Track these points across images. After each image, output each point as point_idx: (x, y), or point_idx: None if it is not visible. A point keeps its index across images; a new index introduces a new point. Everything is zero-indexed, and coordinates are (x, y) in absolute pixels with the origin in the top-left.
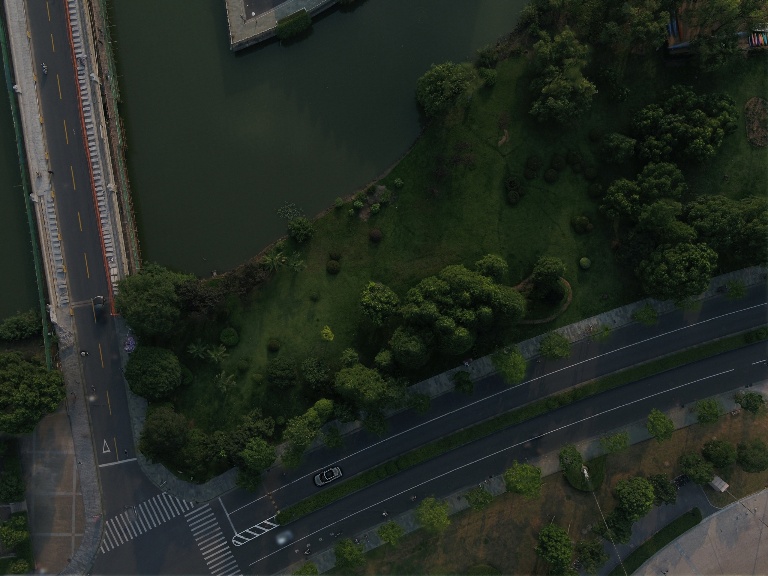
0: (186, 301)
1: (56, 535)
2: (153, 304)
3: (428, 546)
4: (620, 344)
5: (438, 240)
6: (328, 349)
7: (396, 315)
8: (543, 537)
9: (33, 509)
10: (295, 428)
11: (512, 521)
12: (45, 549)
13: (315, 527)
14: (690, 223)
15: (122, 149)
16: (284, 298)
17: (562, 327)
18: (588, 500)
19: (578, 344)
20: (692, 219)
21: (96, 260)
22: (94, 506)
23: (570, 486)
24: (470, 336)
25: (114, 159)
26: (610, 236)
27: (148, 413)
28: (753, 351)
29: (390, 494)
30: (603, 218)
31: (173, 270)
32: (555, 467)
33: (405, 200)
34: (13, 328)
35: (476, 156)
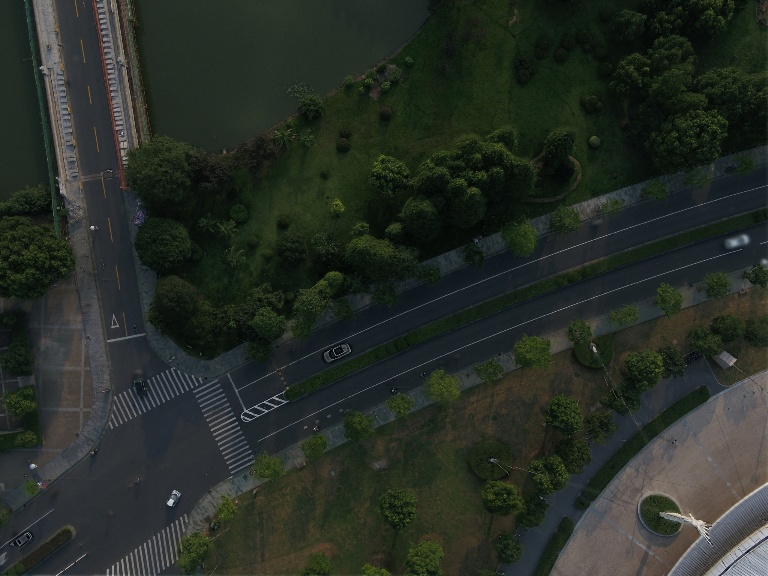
0: (196, 171)
1: (64, 410)
2: (164, 169)
3: (437, 422)
4: (629, 223)
5: (448, 119)
6: (338, 226)
7: (406, 188)
8: (552, 405)
9: (41, 383)
10: (306, 295)
11: (521, 398)
12: (53, 424)
13: (324, 404)
14: (701, 91)
15: (132, 25)
16: (294, 176)
17: (571, 205)
18: (596, 378)
19: (587, 223)
20: (703, 88)
21: (106, 134)
22: (102, 381)
23: (579, 364)
24: (482, 197)
25: (124, 34)
26: (620, 116)
27: (158, 285)
28: (761, 231)
29: (399, 371)
30: (613, 98)
31: (183, 142)
32: (564, 345)
33: (415, 79)
34: (22, 201)
35: (486, 36)
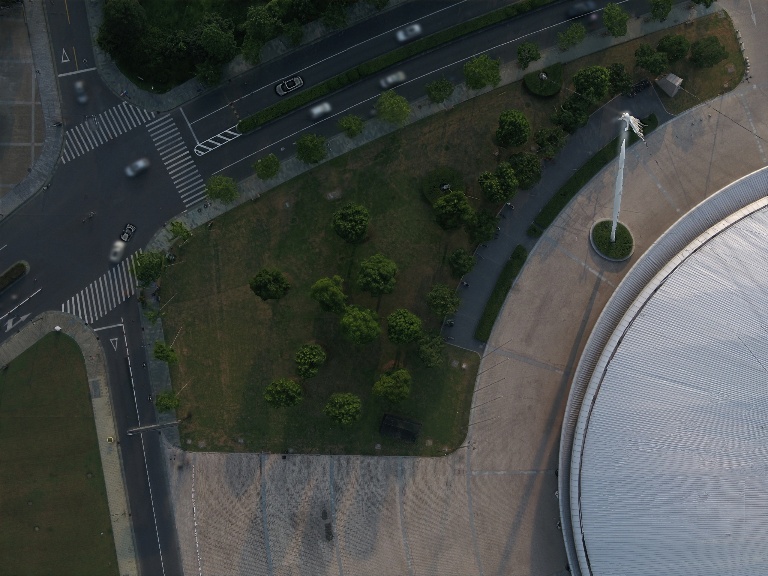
0: None
1: (15, 145)
2: None
3: (390, 153)
4: None
5: None
6: None
7: None
8: (502, 116)
9: None
10: (254, 8)
11: (473, 128)
12: (4, 159)
13: (277, 137)
14: None
15: None
16: None
17: None
18: (547, 107)
19: None
20: None
21: None
22: (54, 115)
23: (529, 94)
24: None
25: None
26: None
27: None
28: None
29: (352, 103)
30: None
31: None
32: (514, 76)
33: None
34: None
35: None
